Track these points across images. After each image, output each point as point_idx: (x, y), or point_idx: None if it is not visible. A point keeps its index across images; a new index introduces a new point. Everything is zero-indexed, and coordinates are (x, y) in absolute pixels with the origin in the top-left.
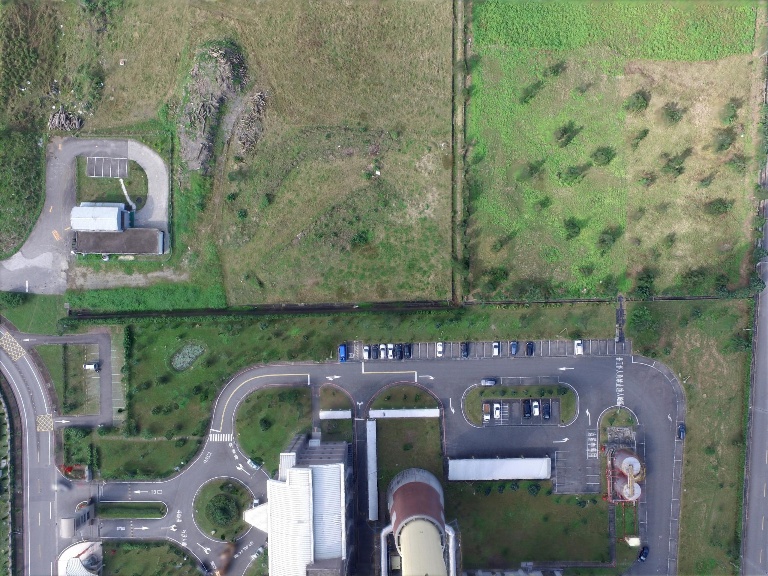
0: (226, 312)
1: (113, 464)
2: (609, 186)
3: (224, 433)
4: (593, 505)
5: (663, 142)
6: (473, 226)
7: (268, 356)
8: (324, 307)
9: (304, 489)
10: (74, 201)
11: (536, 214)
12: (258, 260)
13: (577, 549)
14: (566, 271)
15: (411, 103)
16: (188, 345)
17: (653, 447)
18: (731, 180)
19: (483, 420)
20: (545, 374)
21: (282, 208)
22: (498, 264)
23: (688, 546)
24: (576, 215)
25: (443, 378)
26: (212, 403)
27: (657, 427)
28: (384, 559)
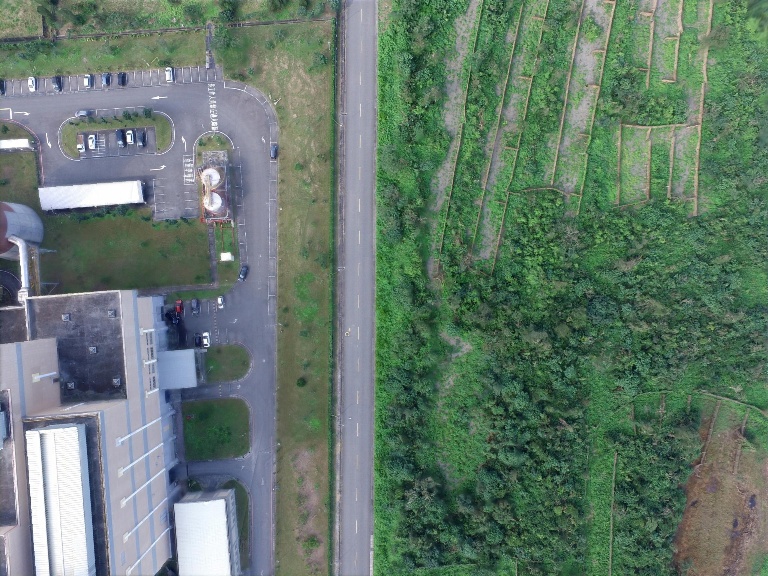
0: None
1: None
2: None
3: None
4: (192, 229)
5: None
6: None
7: None
8: None
9: None
10: None
11: None
12: None
13: (179, 273)
14: (155, 2)
15: None
16: None
17: (249, 169)
18: None
19: (80, 152)
20: (139, 104)
21: None
22: None
23: (286, 263)
24: None
25: (38, 113)
26: None
27: (252, 150)
28: None
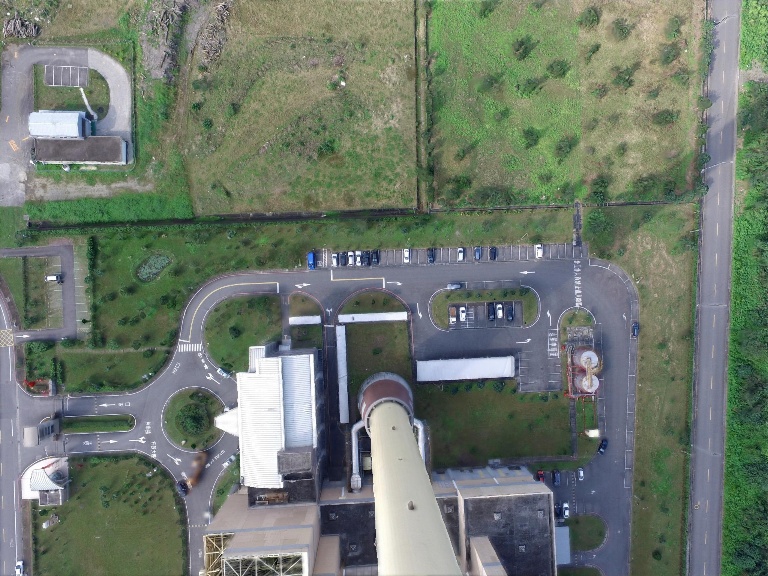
0: (193, 222)
1: (78, 378)
2: (565, 97)
3: (193, 343)
4: (555, 402)
5: (614, 56)
6: (437, 136)
7: (236, 265)
8: (292, 217)
9: (274, 377)
10: (32, 110)
11: (497, 124)
12: (225, 170)
13: (541, 444)
14: (526, 179)
15: (375, 16)
16: (154, 256)
17: (610, 345)
18: (677, 92)
19: (449, 323)
20: (508, 278)
21: (248, 118)
22: (461, 172)
23: (643, 437)
24: (534, 125)
25: (410, 284)
26: (180, 313)
27: (613, 326)
28: (355, 454)
